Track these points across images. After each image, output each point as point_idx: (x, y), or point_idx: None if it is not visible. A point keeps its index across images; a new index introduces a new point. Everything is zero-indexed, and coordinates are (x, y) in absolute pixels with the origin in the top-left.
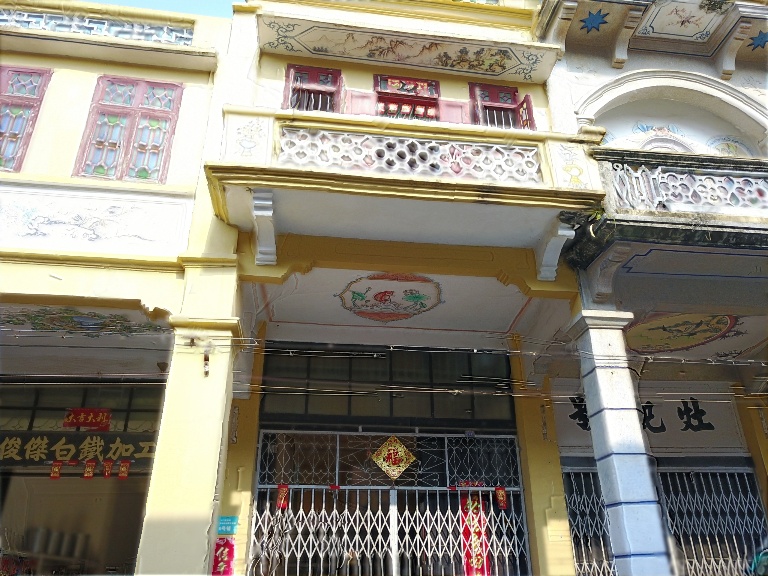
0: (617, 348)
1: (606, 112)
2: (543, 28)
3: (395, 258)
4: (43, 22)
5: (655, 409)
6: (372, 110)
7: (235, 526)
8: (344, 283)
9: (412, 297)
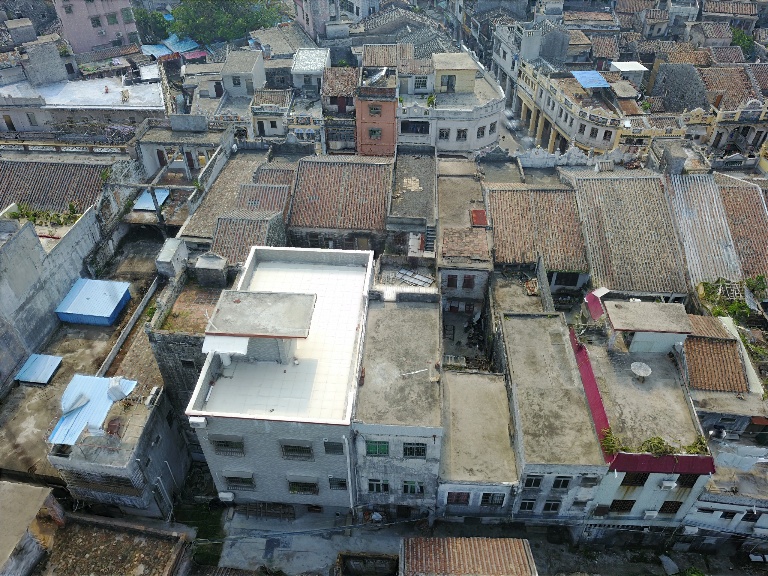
0: None
1: None
2: None
3: None
4: (14, 146)
5: None
6: None
7: None
8: None
9: None
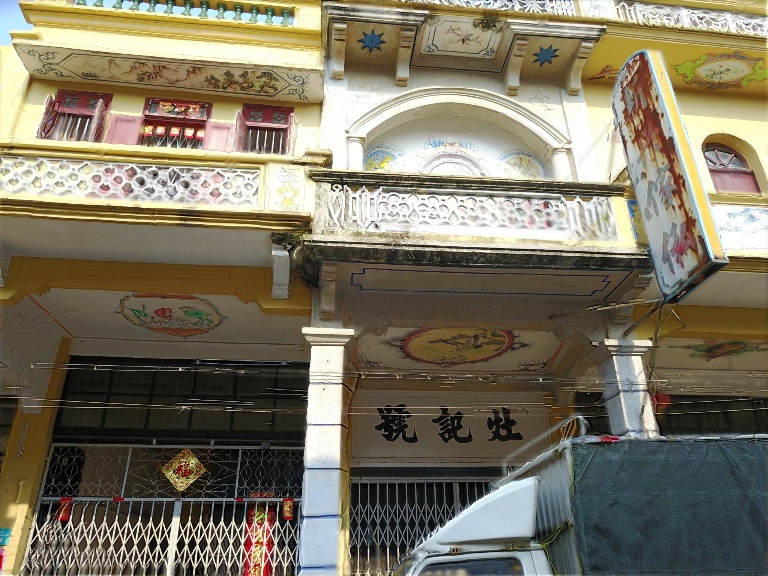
0: (335, 364)
1: (391, 129)
2: (326, 48)
3: (131, 278)
4: None
5: (464, 419)
6: (135, 133)
7: (7, 538)
8: (114, 301)
9: (193, 313)
